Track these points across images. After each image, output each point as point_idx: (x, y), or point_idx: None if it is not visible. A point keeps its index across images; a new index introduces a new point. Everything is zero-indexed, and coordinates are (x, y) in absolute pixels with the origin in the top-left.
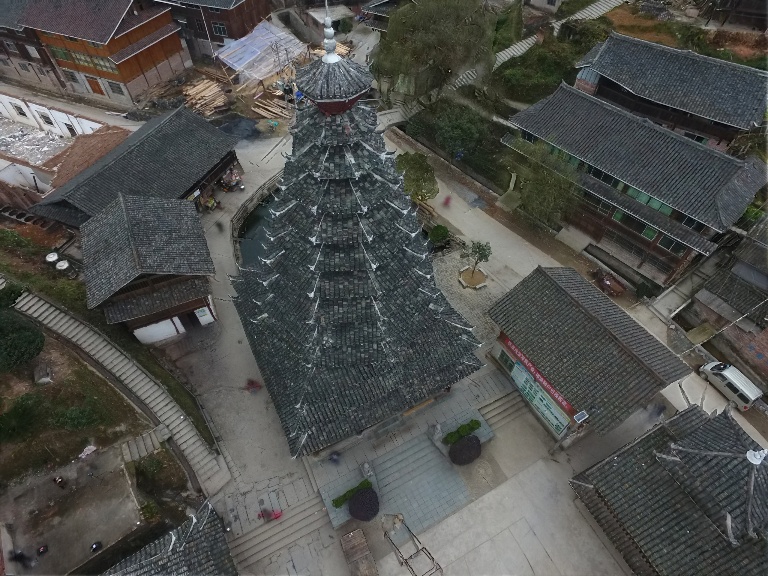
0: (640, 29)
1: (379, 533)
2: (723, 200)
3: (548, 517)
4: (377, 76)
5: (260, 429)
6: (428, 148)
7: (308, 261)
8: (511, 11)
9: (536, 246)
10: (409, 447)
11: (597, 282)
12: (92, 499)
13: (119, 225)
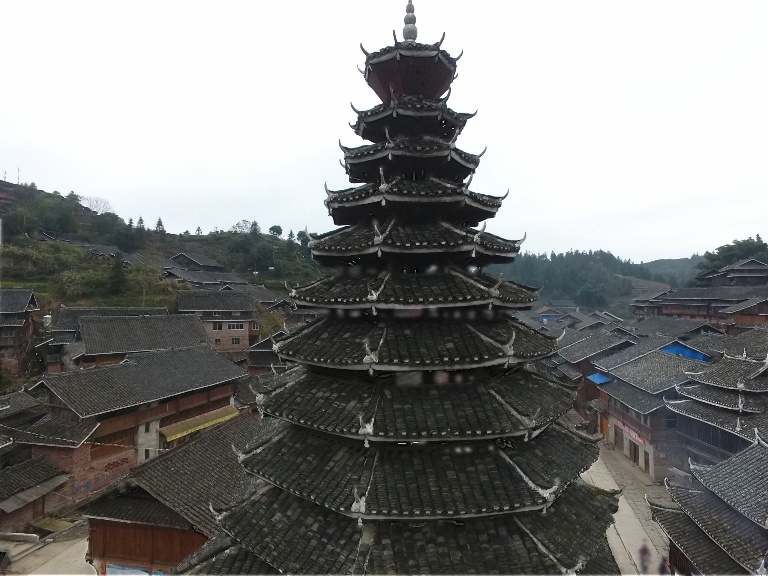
0: None
1: None
2: None
3: None
4: None
5: None
6: None
7: None
8: None
9: None
10: None
11: None
12: None
13: None
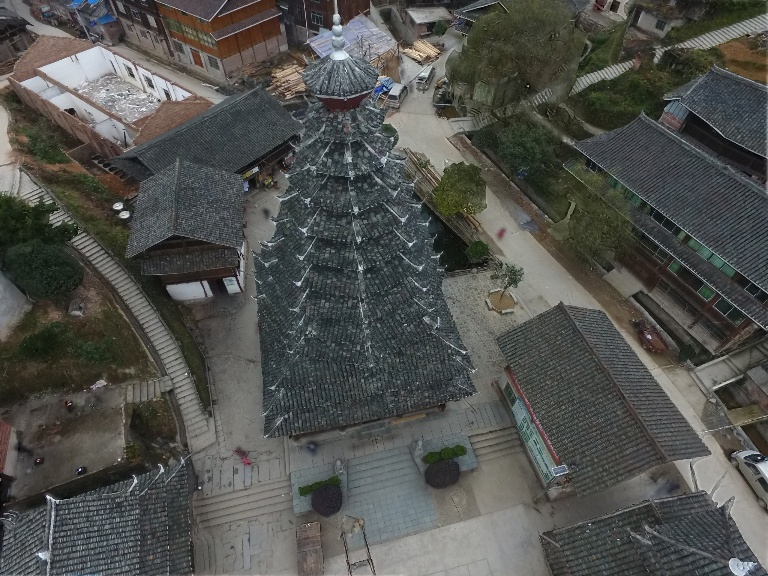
0: (755, 67)
1: (337, 532)
2: None
3: (512, 566)
4: (451, 82)
5: (254, 402)
6: (492, 162)
7: (300, 251)
8: (614, 31)
9: (579, 282)
10: (388, 456)
11: (637, 333)
12: (90, 428)
13: (170, 187)
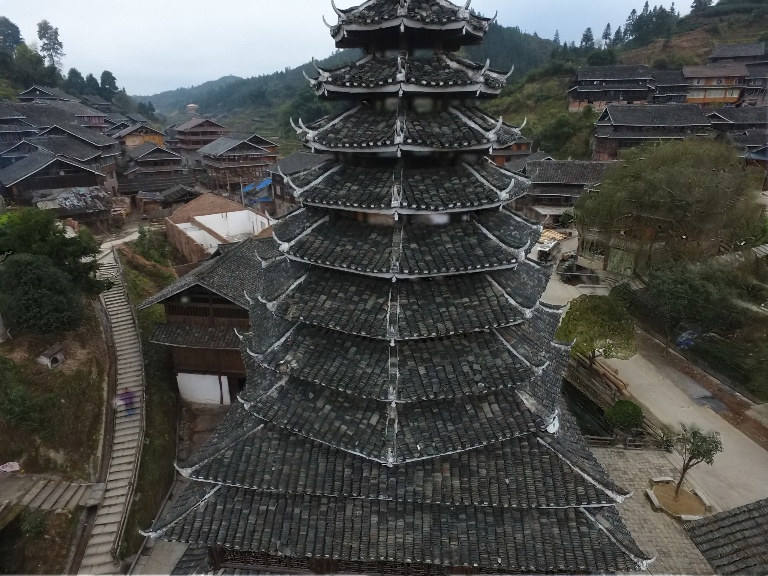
0: None
1: None
2: None
3: None
4: (581, 228)
5: None
6: None
7: None
8: None
9: None
10: None
11: None
12: None
13: None
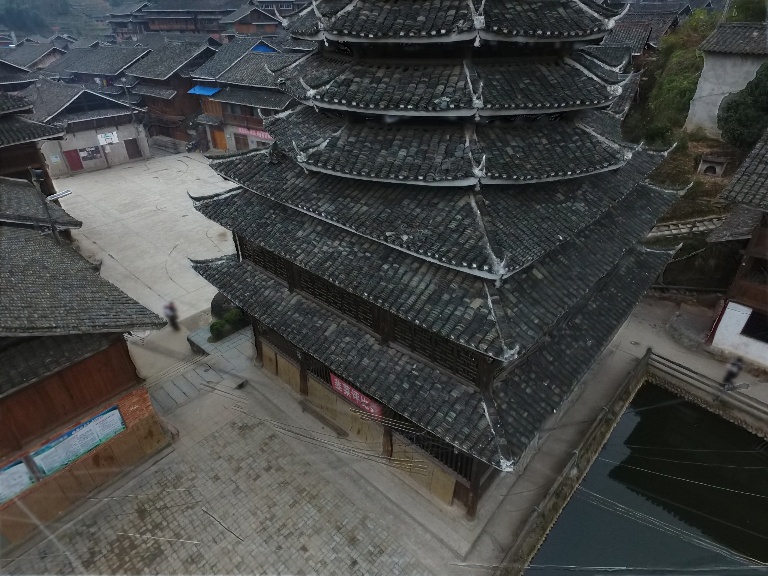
0: None
1: None
2: None
3: None
4: None
5: None
6: None
7: None
8: None
9: None
10: None
11: None
12: None
13: None
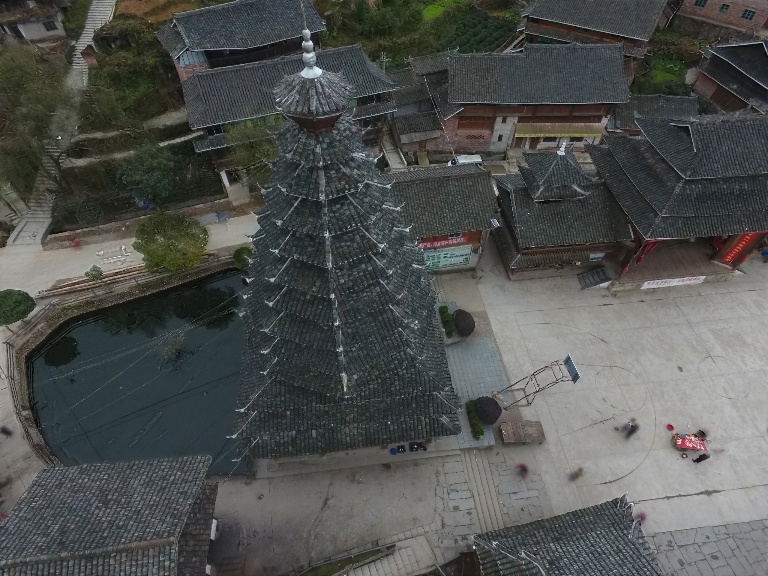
0: (160, 9)
1: (503, 414)
2: (374, 73)
3: (517, 299)
4: None
5: (380, 495)
6: (114, 222)
7: (380, 273)
8: None
9: None
10: None
11: None
12: None
13: None
